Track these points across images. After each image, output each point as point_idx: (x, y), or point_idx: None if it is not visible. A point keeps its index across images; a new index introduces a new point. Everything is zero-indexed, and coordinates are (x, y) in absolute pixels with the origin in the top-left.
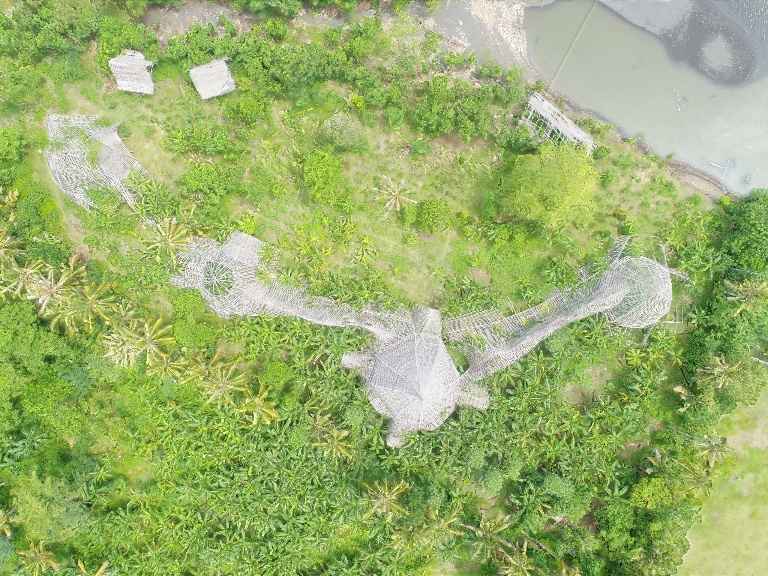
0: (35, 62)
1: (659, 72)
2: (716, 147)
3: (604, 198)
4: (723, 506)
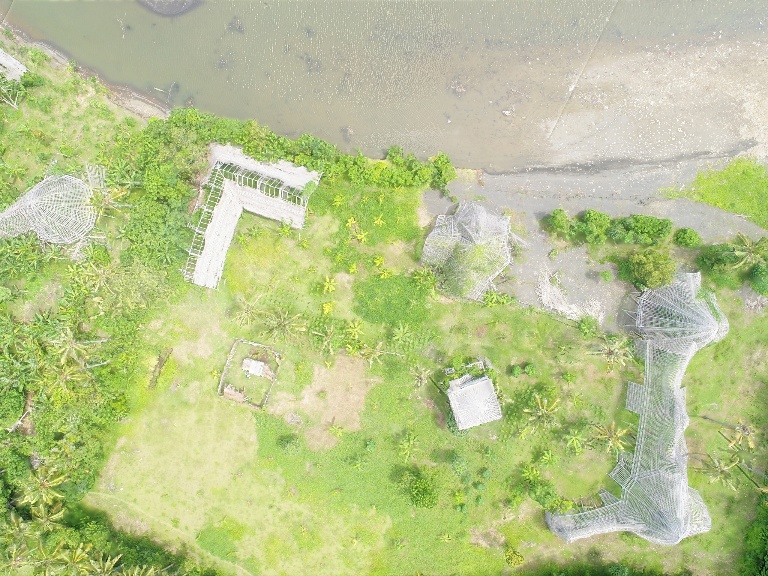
0: None
1: (104, 3)
2: (161, 73)
3: (49, 123)
4: (172, 413)
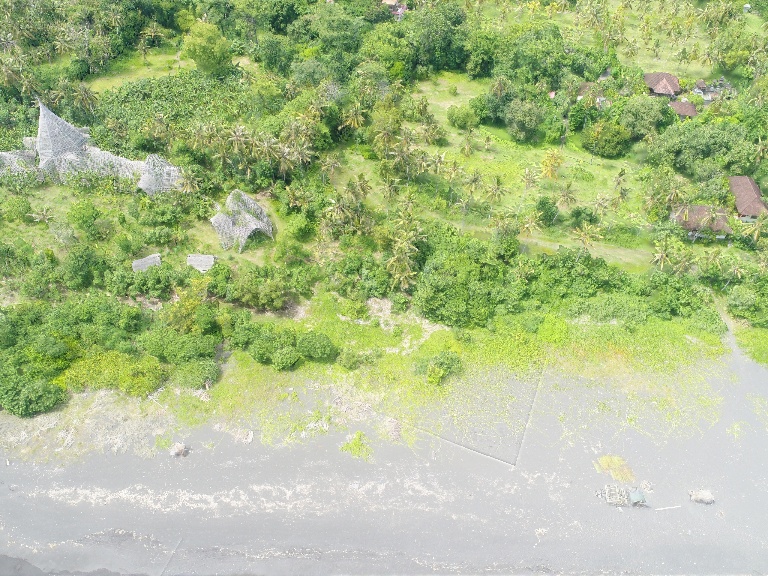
0: (285, 277)
1: None
2: None
3: None
4: None
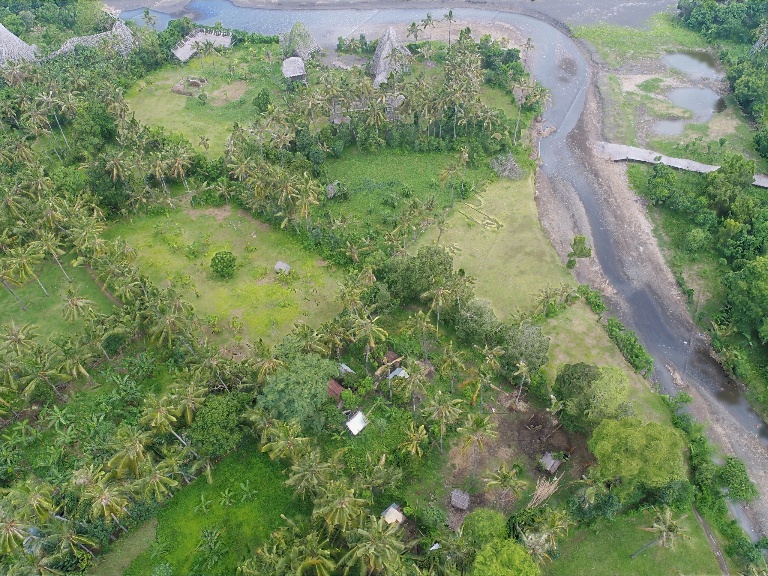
0: None
1: None
2: None
3: None
4: (145, 98)
